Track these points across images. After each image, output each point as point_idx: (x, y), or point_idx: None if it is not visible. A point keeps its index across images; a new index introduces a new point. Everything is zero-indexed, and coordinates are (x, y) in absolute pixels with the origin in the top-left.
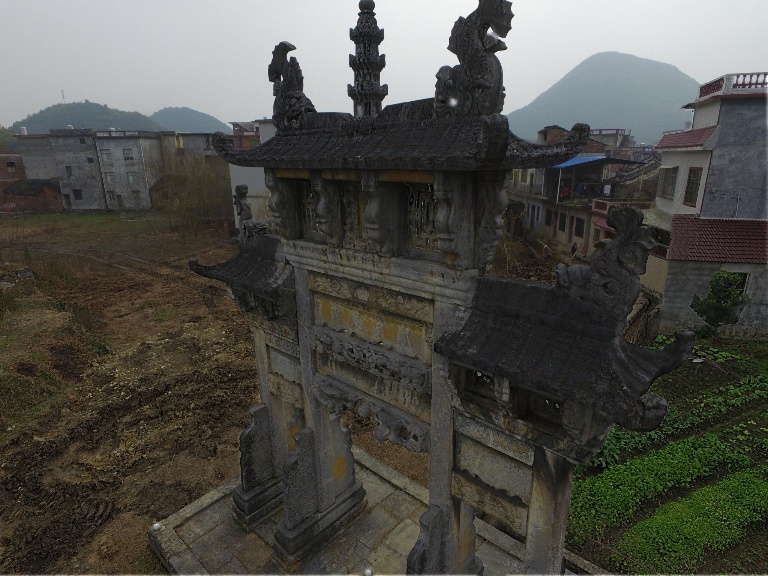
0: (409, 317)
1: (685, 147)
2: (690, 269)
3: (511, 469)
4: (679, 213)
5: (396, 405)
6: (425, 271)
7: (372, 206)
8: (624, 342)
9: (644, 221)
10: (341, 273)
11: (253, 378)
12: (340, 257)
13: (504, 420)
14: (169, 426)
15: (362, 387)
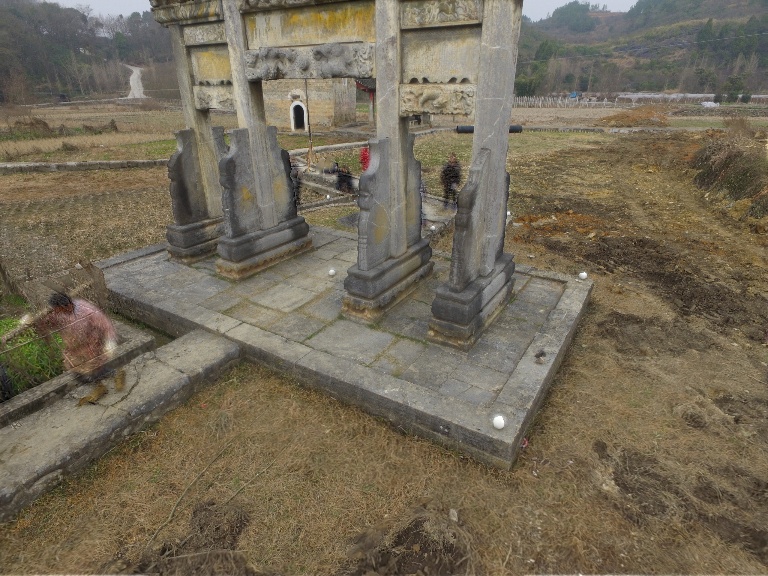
0: None
1: None
2: None
3: None
4: None
5: None
6: None
7: None
8: None
9: None
10: None
11: None
12: None
13: None
14: None
15: None
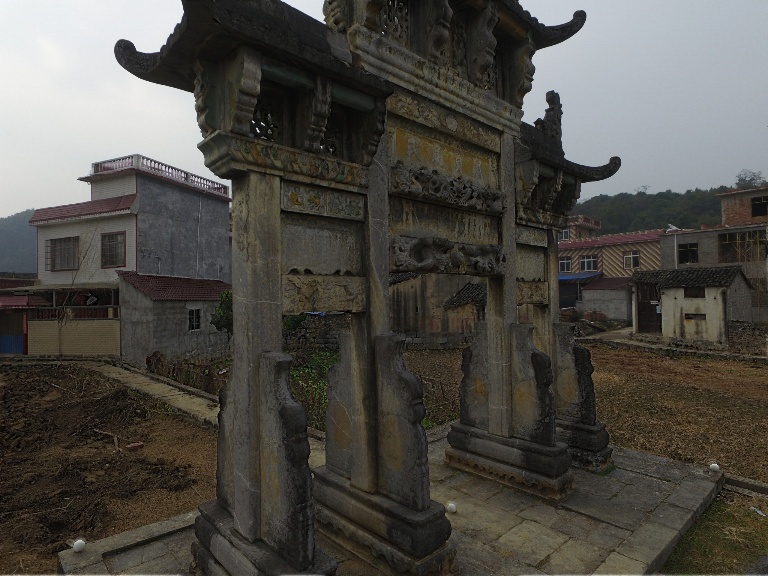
0: (485, 148)
1: (96, 214)
2: (168, 308)
3: (536, 259)
4: (97, 278)
5: (474, 242)
6: (502, 106)
7: (491, 34)
8: None
9: (65, 287)
10: (435, 95)
11: None
12: (438, 76)
13: (542, 216)
14: None
15: (444, 235)
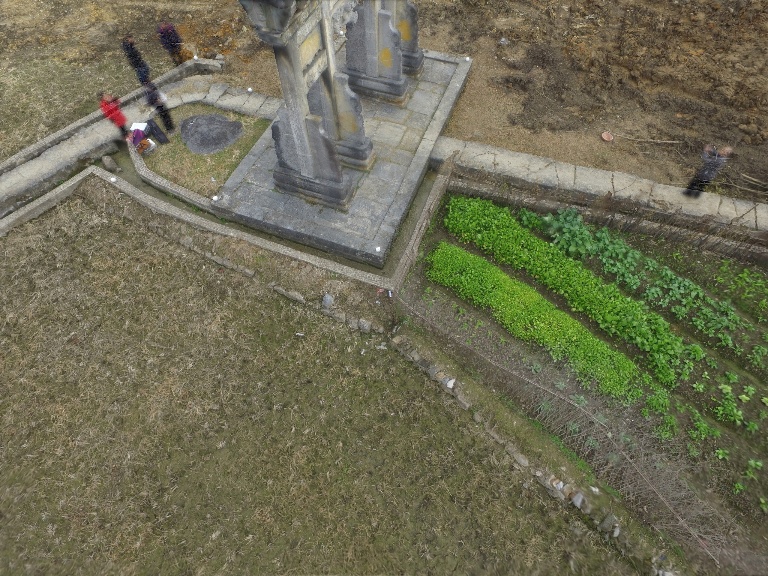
0: None
1: None
2: None
3: None
4: None
5: None
6: None
7: None
8: None
9: None
10: None
11: (523, 5)
12: None
13: None
14: (437, 0)
15: None
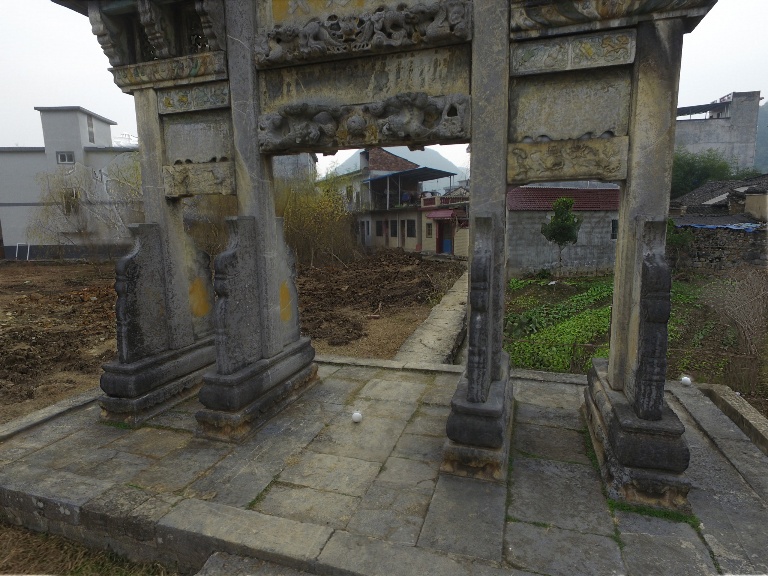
0: None
1: None
2: (525, 218)
3: (597, 95)
4: None
5: None
6: None
7: None
8: None
9: None
10: None
11: None
12: None
13: (596, 3)
14: None
15: (347, 98)
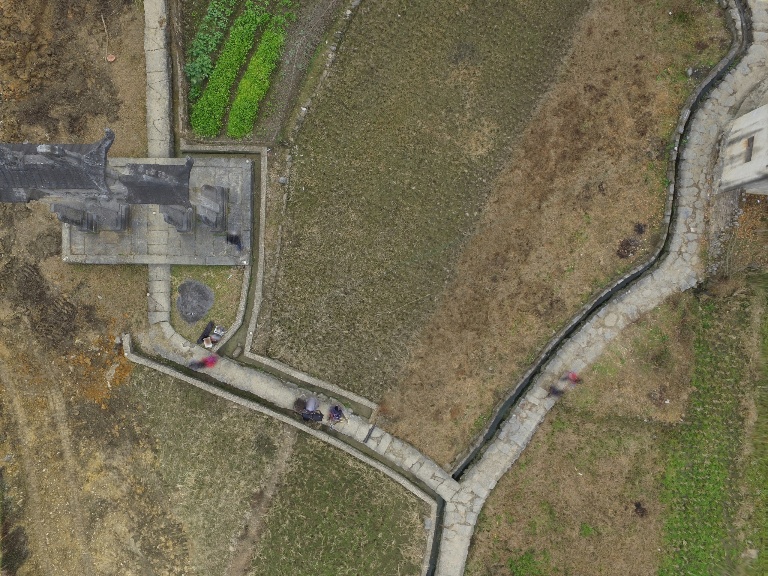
0: None
1: None
2: None
3: None
4: None
5: None
6: None
7: None
8: (175, 177)
9: None
10: None
11: None
12: None
13: None
14: None
15: None
